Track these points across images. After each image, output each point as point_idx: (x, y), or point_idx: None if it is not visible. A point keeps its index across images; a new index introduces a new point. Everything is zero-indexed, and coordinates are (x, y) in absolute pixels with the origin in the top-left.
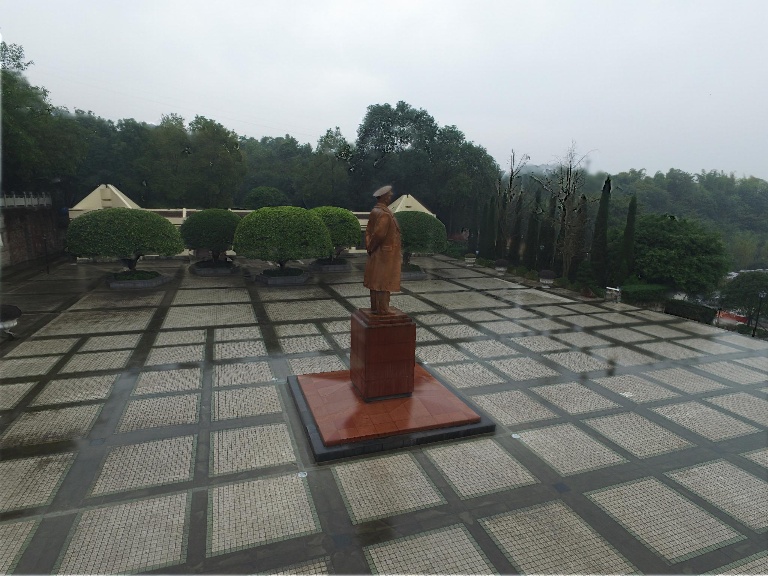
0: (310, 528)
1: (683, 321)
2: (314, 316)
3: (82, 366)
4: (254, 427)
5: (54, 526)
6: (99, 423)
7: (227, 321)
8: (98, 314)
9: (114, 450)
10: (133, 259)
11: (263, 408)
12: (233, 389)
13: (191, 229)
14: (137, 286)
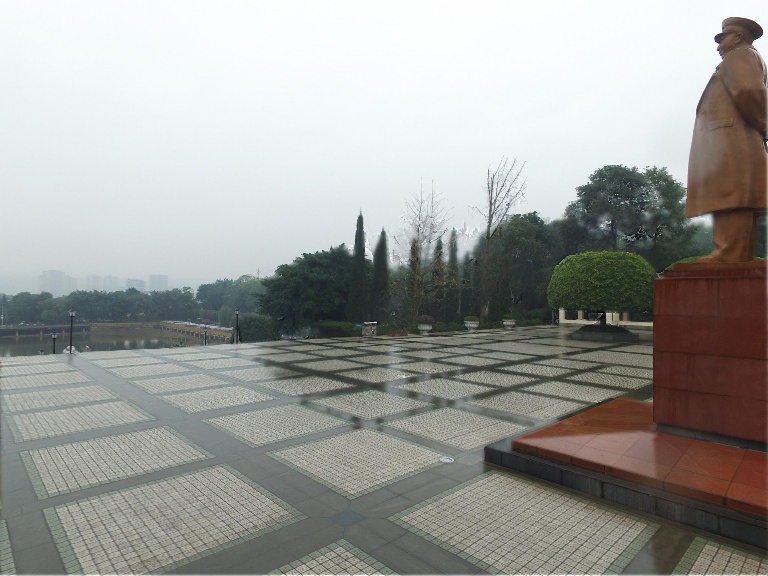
0: None
1: (72, 355)
2: None
3: None
4: None
5: None
6: None
7: None
8: None
9: None
10: None
11: None
12: None
13: None
14: None
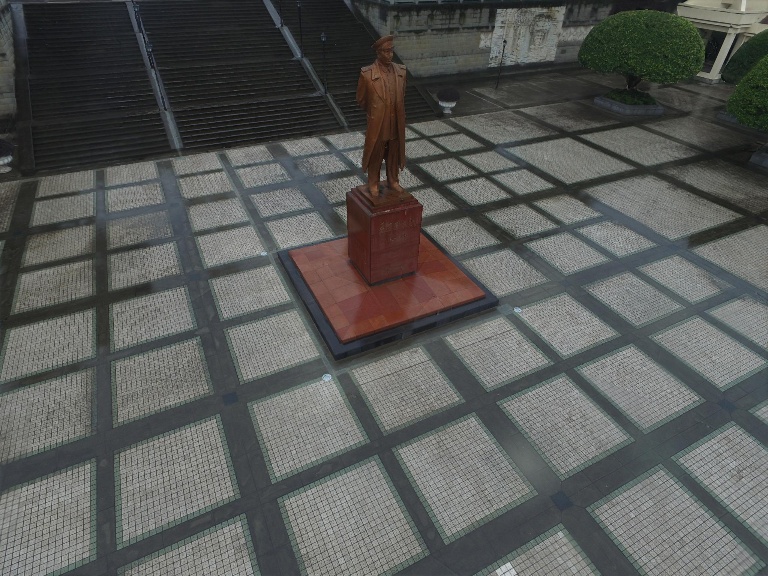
0: (208, 264)
1: None
2: (633, 211)
3: None
4: (326, 225)
5: (228, 195)
6: (325, 175)
7: (555, 169)
8: (516, 120)
9: (293, 188)
10: (638, 77)
11: None
12: None
13: (740, 52)
14: (613, 108)
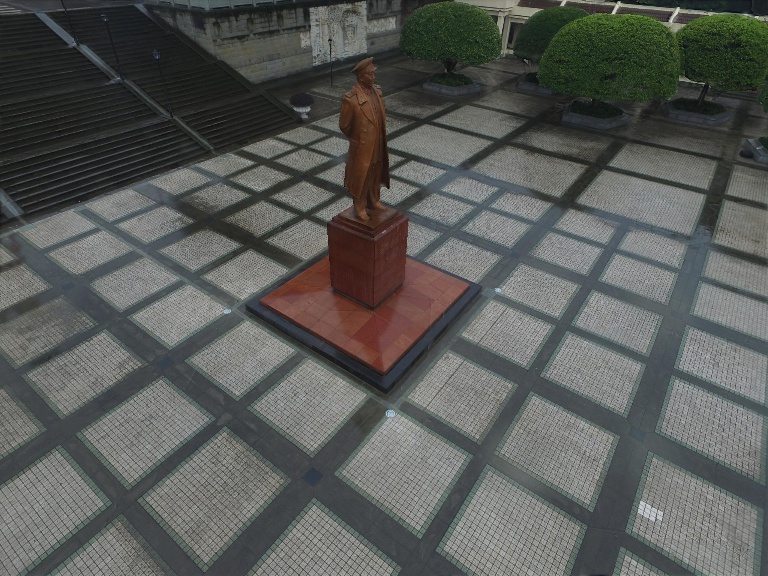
0: (170, 343)
1: None
2: (518, 180)
3: (290, 160)
4: (271, 261)
5: (130, 257)
6: (229, 208)
7: (436, 155)
8: None
9: (205, 230)
10: (453, 61)
11: (301, 250)
12: (317, 223)
13: (524, 32)
14: (442, 91)
